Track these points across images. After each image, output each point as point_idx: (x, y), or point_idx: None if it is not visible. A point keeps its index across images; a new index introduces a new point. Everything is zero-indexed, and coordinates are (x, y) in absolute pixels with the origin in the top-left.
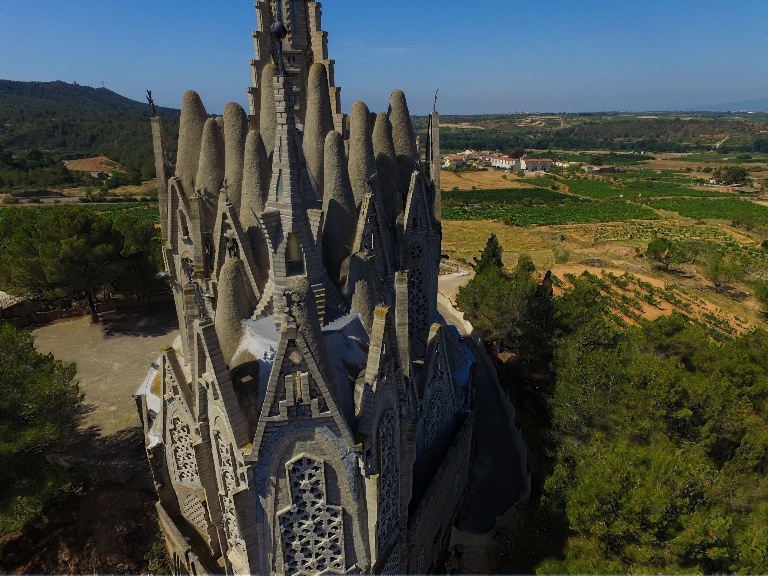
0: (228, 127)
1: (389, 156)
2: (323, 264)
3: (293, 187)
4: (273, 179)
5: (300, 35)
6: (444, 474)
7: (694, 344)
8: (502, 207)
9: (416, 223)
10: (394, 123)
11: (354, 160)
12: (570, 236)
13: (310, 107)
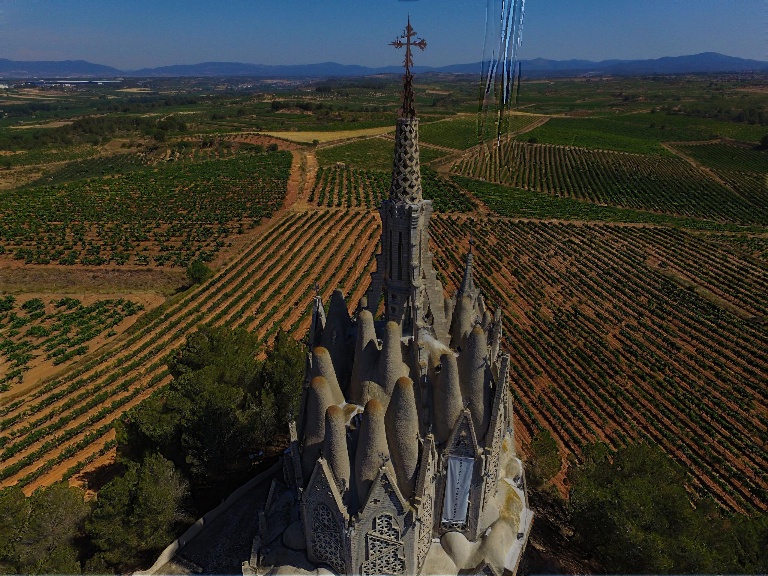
0: None
1: None
2: None
3: None
4: None
5: None
6: None
7: None
8: None
9: None
10: None
11: None
12: None
13: None
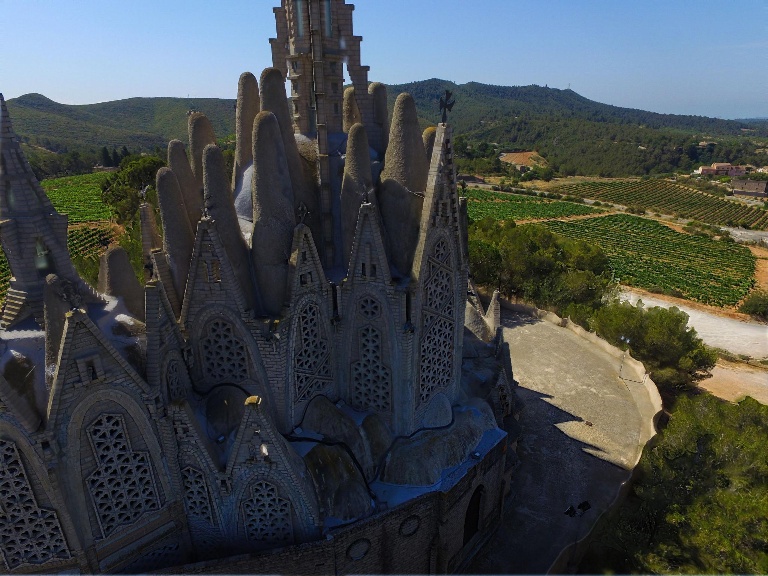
0: None
1: (353, 179)
2: None
3: None
4: None
5: (303, 37)
6: (213, 573)
7: None
8: None
9: (365, 270)
10: (390, 137)
11: None
12: None
13: None
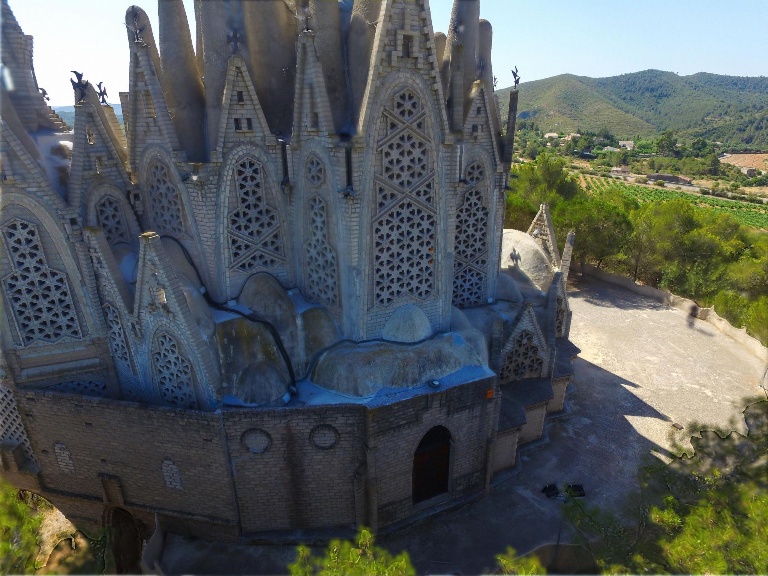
0: None
1: None
2: None
3: None
4: None
5: None
6: (108, 413)
7: None
8: None
9: None
10: None
11: None
12: None
13: None
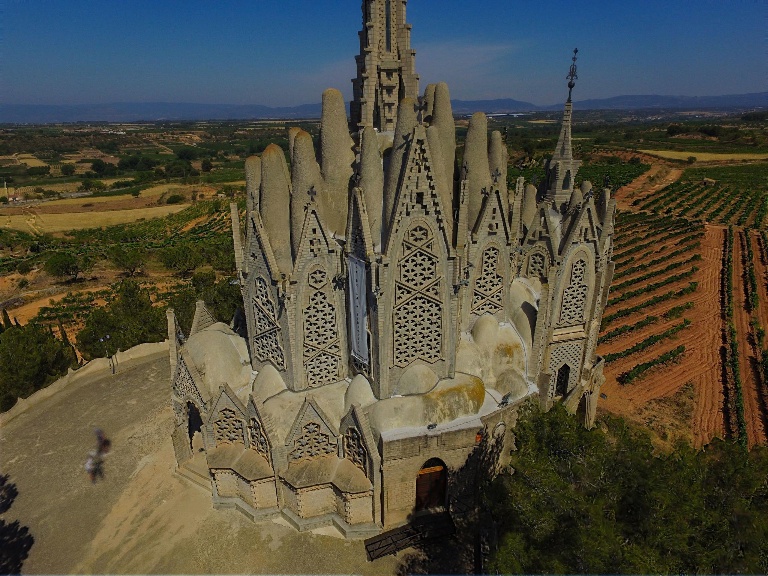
0: None
1: None
2: None
3: None
4: None
5: None
6: None
7: None
8: None
9: None
10: None
11: None
12: None
13: None
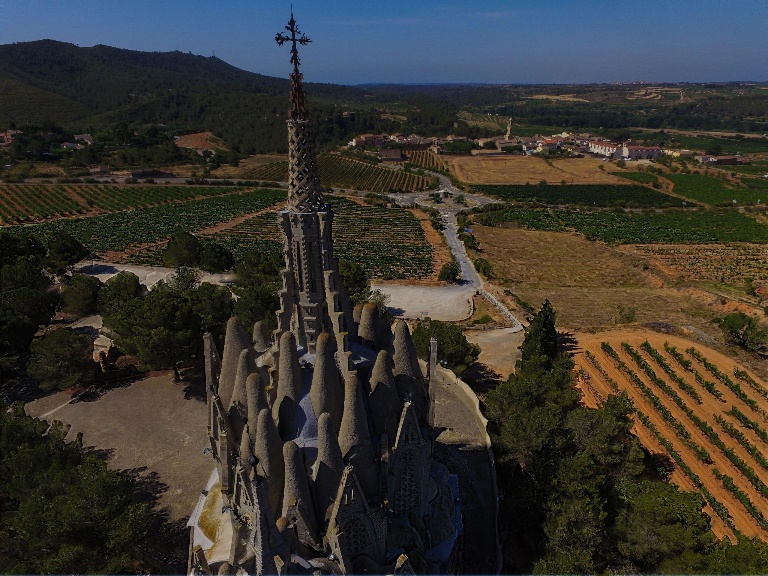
0: (249, 394)
1: (387, 385)
2: (313, 506)
3: (264, 546)
4: (252, 531)
5: (317, 293)
6: None
7: (682, 543)
8: (590, 211)
9: (408, 438)
10: (397, 349)
11: (346, 420)
12: (654, 266)
13: (317, 366)
